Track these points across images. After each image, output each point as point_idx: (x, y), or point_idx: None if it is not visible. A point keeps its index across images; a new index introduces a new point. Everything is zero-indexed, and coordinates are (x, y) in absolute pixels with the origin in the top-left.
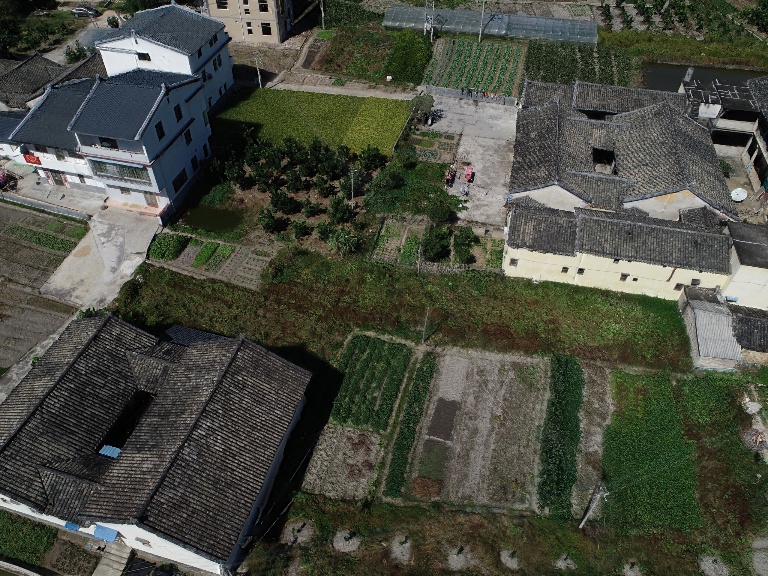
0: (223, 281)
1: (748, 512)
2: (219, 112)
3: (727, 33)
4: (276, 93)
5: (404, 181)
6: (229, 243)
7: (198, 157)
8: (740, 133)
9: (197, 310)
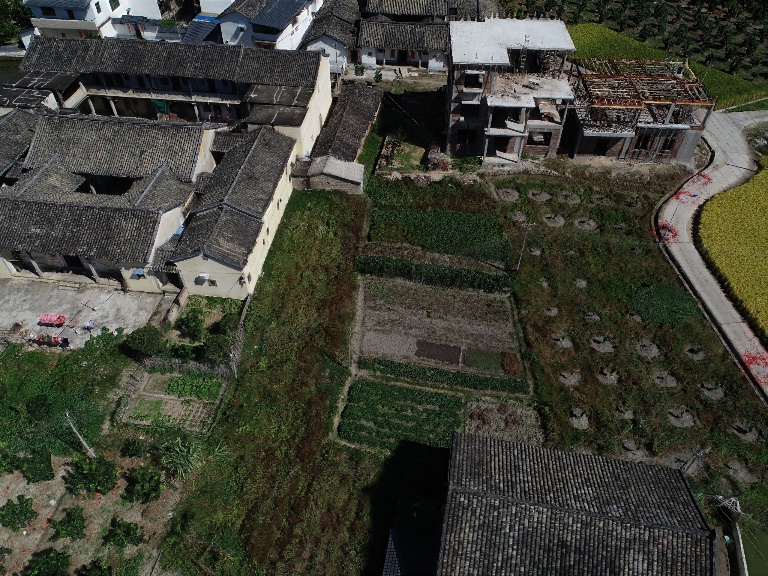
0: None
1: (480, 193)
2: None
3: None
4: None
5: None
6: None
7: None
8: None
9: None
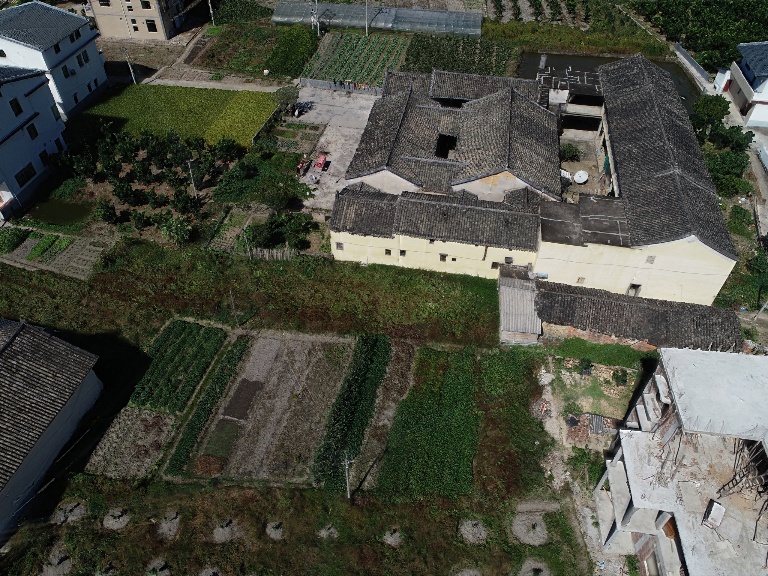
0: (54, 272)
1: (516, 477)
2: (86, 108)
3: (611, 23)
4: (150, 88)
5: (257, 171)
6: (69, 235)
7: (49, 152)
8: (590, 118)
9: (20, 301)
